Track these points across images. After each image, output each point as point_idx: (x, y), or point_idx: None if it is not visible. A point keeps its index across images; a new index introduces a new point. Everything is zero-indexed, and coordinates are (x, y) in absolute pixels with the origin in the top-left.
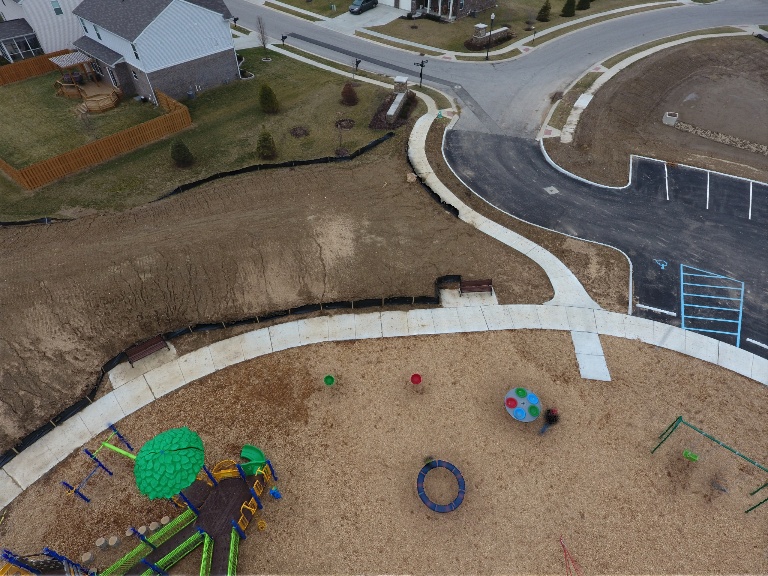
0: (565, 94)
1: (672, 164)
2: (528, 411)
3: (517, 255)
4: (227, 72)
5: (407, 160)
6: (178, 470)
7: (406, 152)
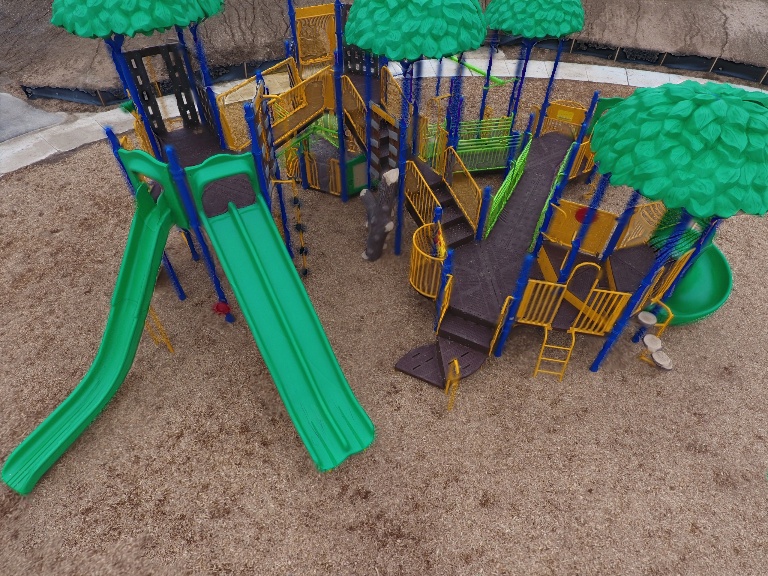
0: None
1: None
2: None
3: None
4: None
5: None
6: (556, 3)
7: None
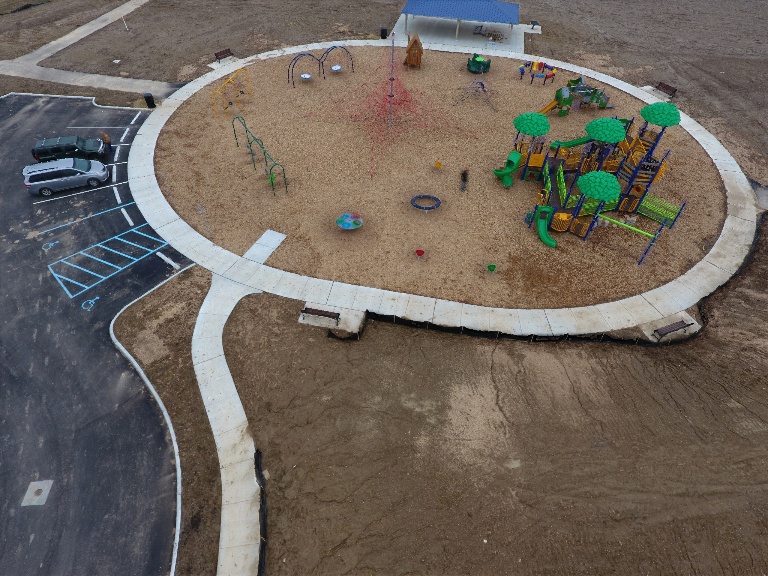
0: None
1: None
2: (349, 217)
3: (235, 355)
4: None
5: None
6: None
7: None
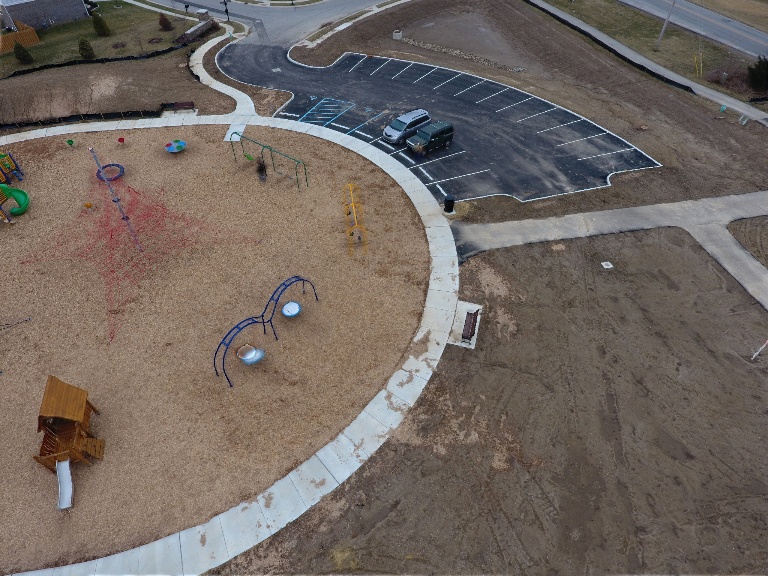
0: (334, 23)
1: (370, 56)
2: (176, 147)
3: (225, 96)
4: (76, 11)
5: (187, 57)
6: None
7: (190, 54)
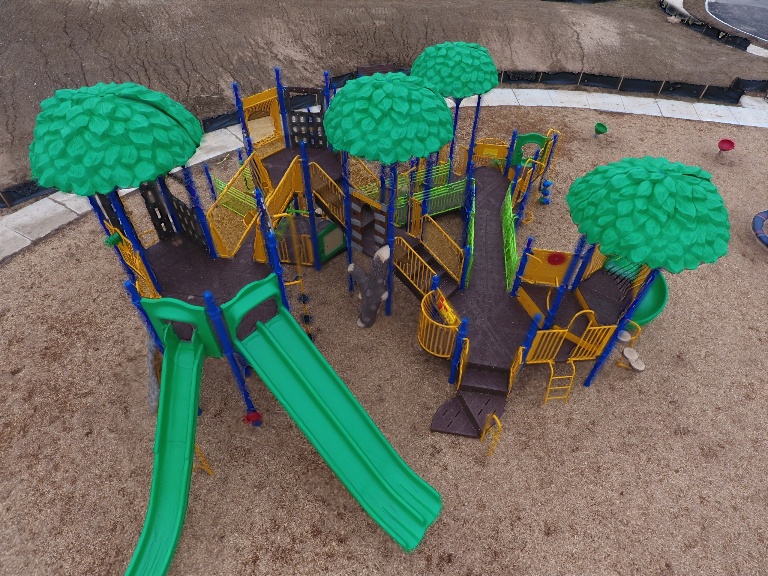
0: None
1: None
2: None
3: None
4: None
5: (664, 10)
6: (476, 65)
7: (660, 6)
